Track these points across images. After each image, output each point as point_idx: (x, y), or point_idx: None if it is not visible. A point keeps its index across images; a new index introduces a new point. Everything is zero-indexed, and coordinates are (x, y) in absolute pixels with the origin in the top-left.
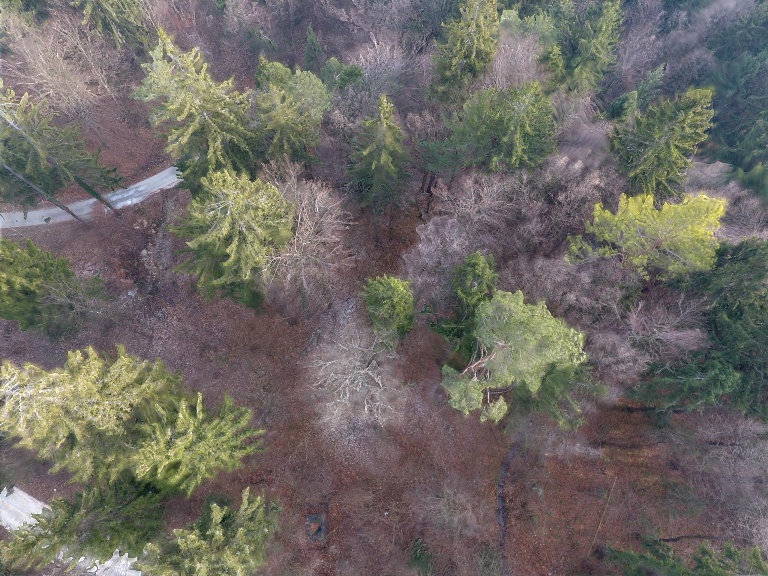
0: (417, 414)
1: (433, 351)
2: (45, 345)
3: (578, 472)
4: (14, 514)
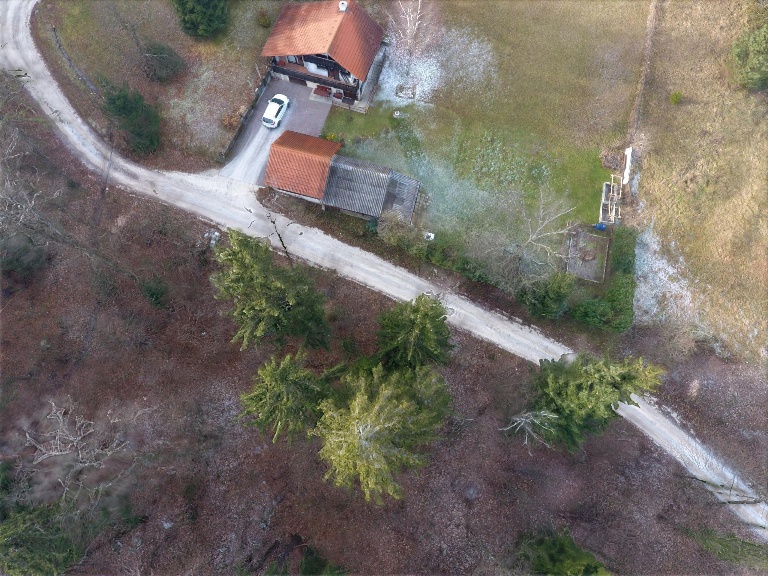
0: (152, 422)
1: (119, 492)
2: (585, 523)
3: (4, 358)
4: (550, 351)
